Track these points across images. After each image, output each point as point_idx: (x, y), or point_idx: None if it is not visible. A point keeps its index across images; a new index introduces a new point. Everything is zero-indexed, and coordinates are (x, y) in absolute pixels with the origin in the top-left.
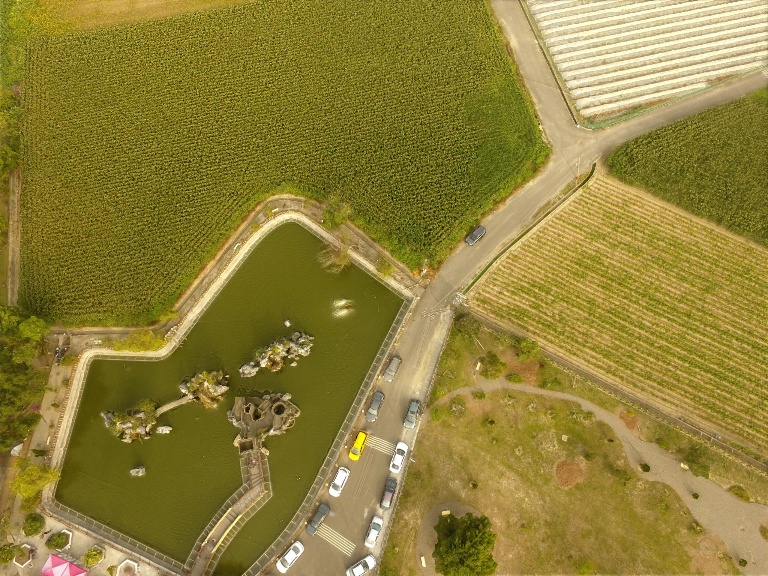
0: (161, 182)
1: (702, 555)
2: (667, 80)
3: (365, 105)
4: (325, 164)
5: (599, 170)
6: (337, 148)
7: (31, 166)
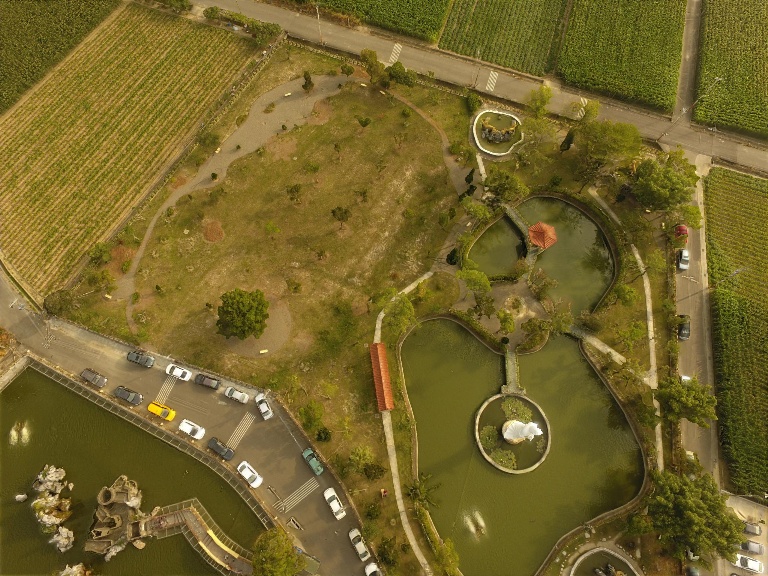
0: None
1: (279, 151)
2: None
3: None
4: None
5: None
6: None
7: None
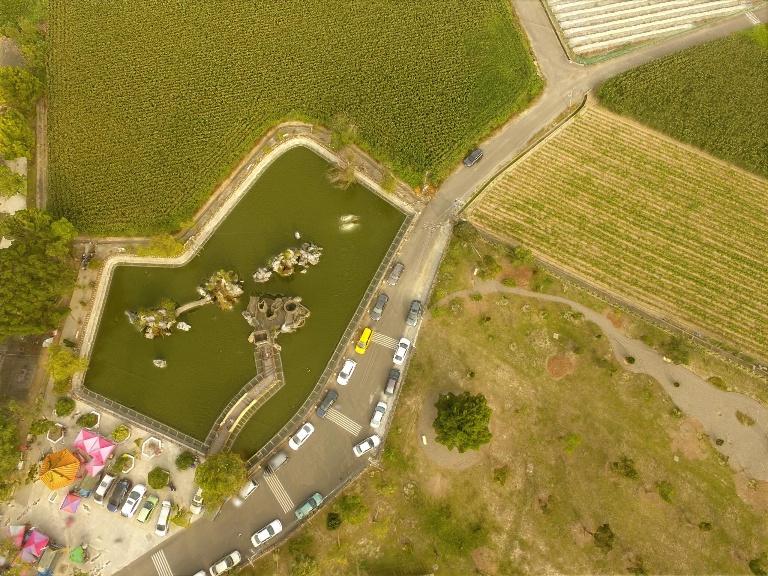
0: (179, 108)
1: (682, 437)
2: (655, 21)
3: (370, 41)
4: (332, 93)
5: (590, 101)
6: (343, 79)
7: (57, 94)
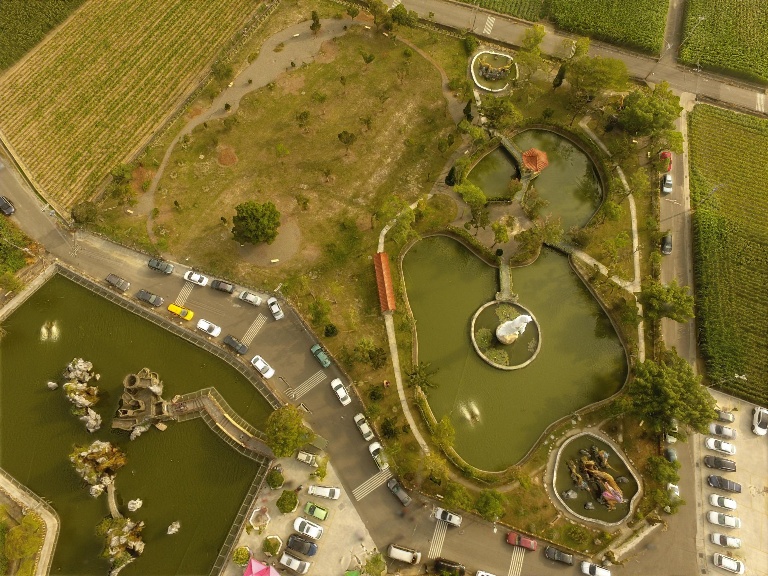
0: None
1: (288, 86)
2: None
3: None
4: None
5: None
6: None
7: None
